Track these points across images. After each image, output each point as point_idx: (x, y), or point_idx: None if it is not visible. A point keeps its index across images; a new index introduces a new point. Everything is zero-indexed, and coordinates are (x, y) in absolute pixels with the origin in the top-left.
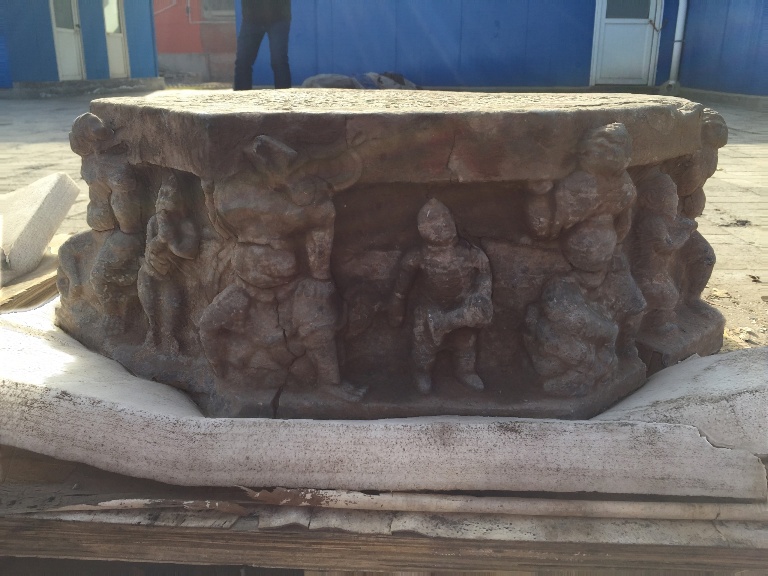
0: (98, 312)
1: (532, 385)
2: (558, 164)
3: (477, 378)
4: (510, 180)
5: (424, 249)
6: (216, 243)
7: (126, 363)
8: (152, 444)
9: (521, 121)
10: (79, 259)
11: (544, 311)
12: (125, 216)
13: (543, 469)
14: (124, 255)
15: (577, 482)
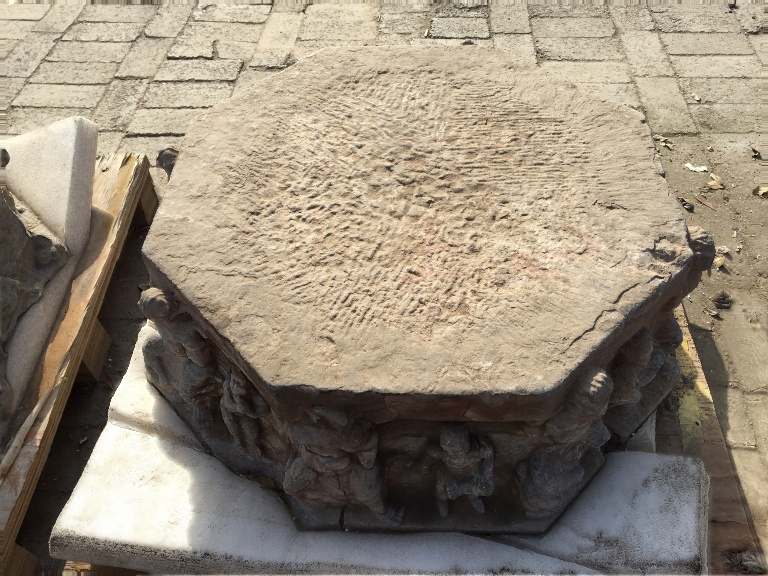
0: None
1: (518, 508)
2: (550, 414)
3: (480, 504)
4: (512, 421)
5: (445, 454)
6: None
7: (223, 459)
8: None
9: (523, 399)
10: (161, 359)
11: (531, 474)
12: (200, 362)
13: None
14: (203, 378)
15: None
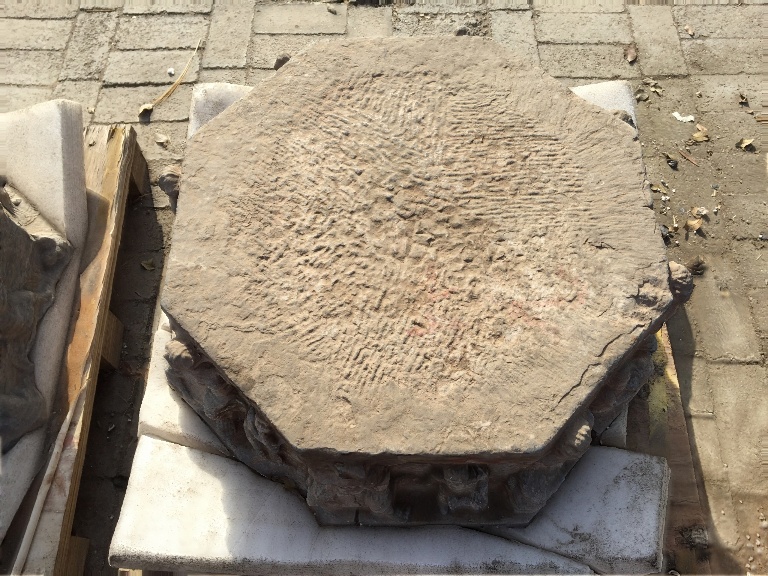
0: None
1: (508, 505)
2: None
3: None
4: None
5: (447, 481)
6: None
7: (248, 463)
8: (298, 570)
9: None
10: (184, 379)
11: (520, 485)
12: None
13: None
14: None
15: None
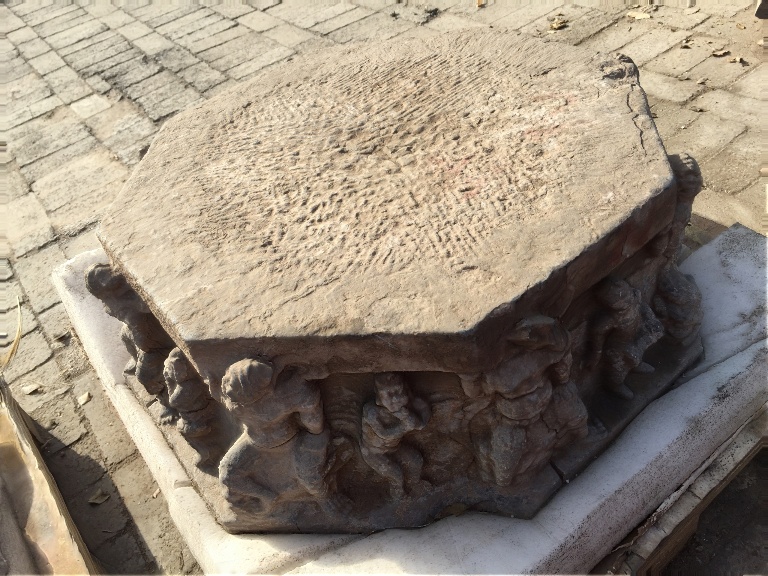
0: (304, 502)
1: (673, 346)
2: None
3: (646, 364)
4: None
5: (616, 316)
6: (456, 402)
7: (396, 524)
8: (557, 572)
9: (661, 199)
10: (253, 475)
11: (669, 299)
12: (321, 422)
13: (747, 405)
14: (324, 449)
15: (762, 399)
